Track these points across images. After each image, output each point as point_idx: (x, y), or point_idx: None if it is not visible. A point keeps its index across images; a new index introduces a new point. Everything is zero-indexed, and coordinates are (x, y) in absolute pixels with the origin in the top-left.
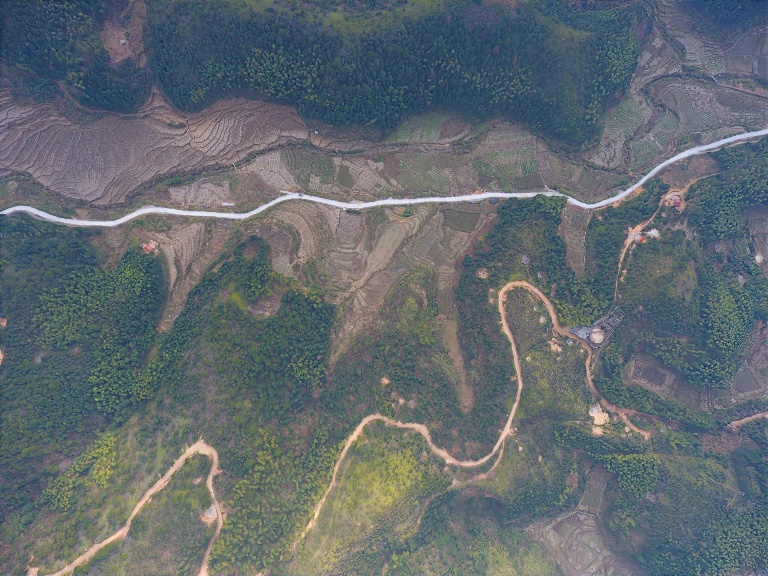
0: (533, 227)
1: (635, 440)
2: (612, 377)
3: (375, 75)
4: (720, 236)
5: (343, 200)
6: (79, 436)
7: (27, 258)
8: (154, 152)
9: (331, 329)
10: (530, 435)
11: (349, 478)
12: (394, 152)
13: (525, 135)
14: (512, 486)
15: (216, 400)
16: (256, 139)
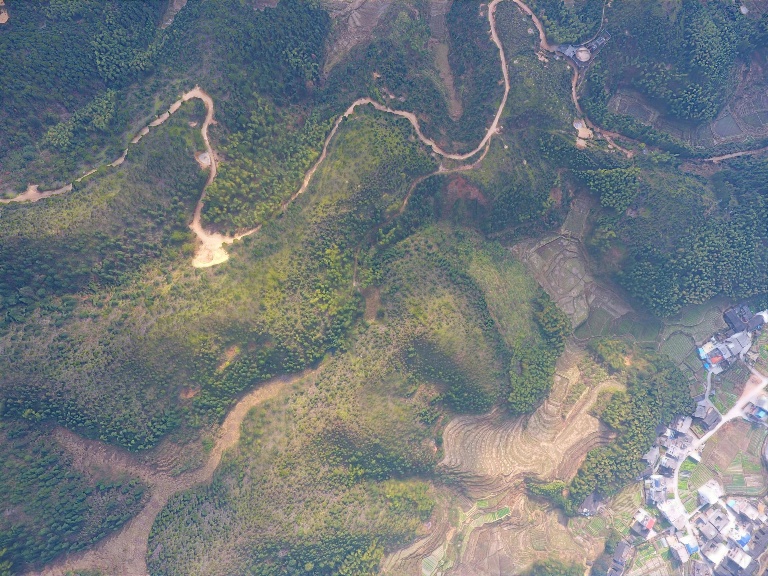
0: None
1: (618, 156)
2: (597, 101)
3: None
4: None
5: None
6: (80, 97)
7: None
8: None
9: (326, 39)
10: (516, 140)
11: (339, 145)
12: None
13: None
14: (497, 181)
15: (213, 59)
16: None
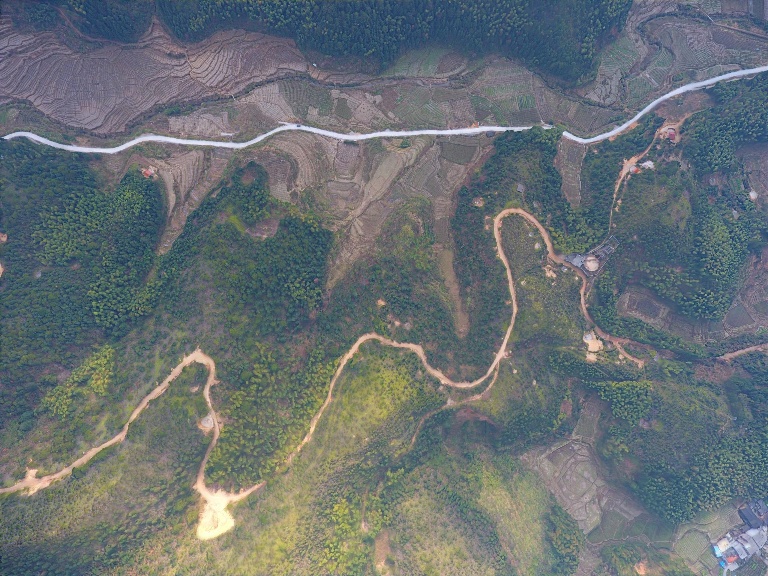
0: (529, 157)
1: (629, 367)
2: (606, 306)
3: (373, 3)
4: (714, 168)
5: (341, 131)
6: (78, 349)
7: (27, 178)
8: (154, 82)
9: (328, 255)
10: (524, 359)
11: (345, 393)
12: (392, 86)
13: (522, 71)
14: (506, 408)
15: (213, 313)
16: (255, 71)
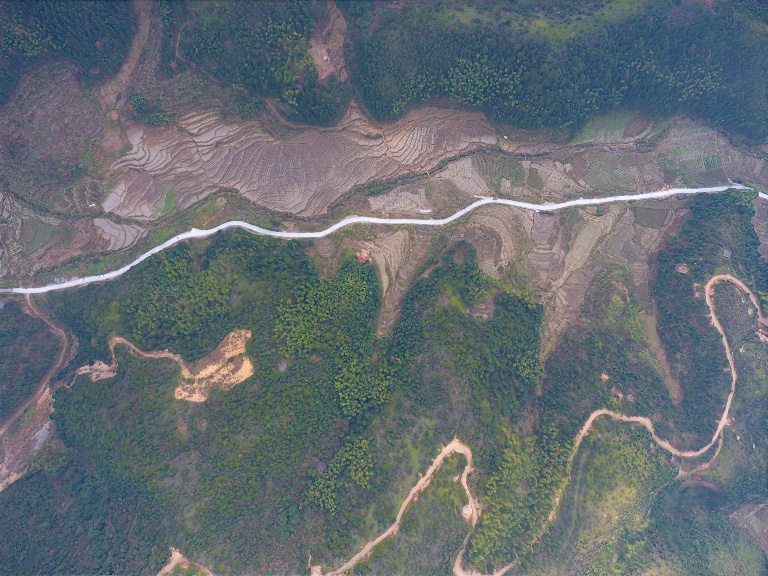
0: (731, 221)
1: None
2: None
3: (576, 79)
4: None
5: (536, 202)
6: (328, 440)
7: (257, 271)
8: (352, 163)
9: (539, 328)
10: (743, 424)
11: (589, 472)
12: (580, 153)
13: (706, 130)
14: (732, 474)
15: (462, 401)
16: (448, 146)
